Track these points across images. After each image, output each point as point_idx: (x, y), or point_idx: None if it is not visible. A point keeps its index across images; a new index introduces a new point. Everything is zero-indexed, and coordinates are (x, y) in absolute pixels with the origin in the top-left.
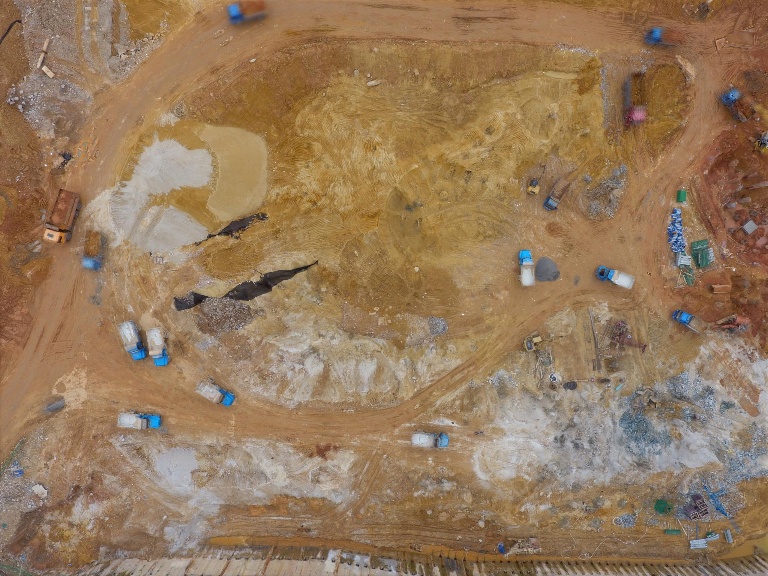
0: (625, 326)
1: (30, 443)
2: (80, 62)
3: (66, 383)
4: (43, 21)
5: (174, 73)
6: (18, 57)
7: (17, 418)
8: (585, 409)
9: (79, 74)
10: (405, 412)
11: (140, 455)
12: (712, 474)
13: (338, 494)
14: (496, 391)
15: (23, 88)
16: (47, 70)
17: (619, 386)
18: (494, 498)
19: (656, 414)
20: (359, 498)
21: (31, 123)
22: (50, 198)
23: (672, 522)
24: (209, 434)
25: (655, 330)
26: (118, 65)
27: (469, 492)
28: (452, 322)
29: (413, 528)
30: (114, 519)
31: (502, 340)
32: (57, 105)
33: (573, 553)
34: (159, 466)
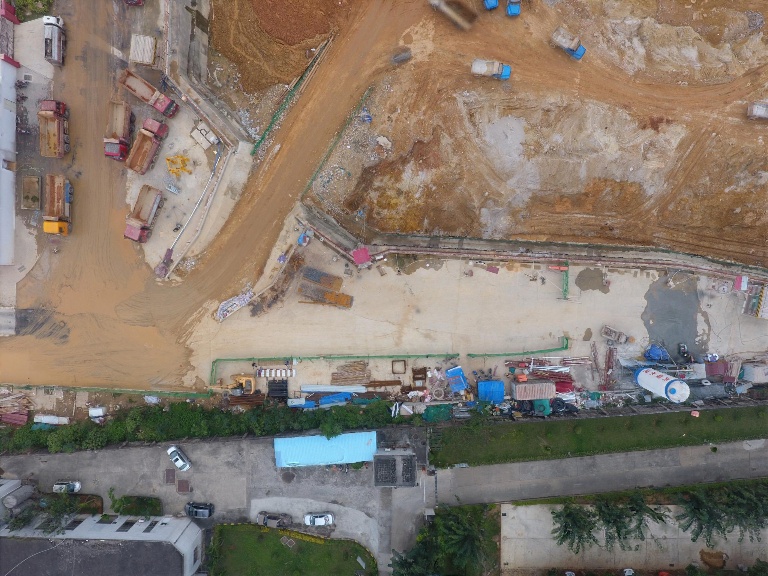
0: None
1: (378, 91)
2: None
3: (413, 34)
4: None
5: None
6: None
7: (366, 65)
8: None
9: None
10: (737, 89)
11: (472, 122)
12: None
13: (652, 184)
14: None
15: None
16: None
17: None
18: None
19: None
20: (670, 191)
21: None
22: None
23: None
24: (553, 92)
25: None
26: None
27: None
28: None
29: (707, 240)
30: (441, 189)
31: None
32: None
33: None
34: (490, 135)
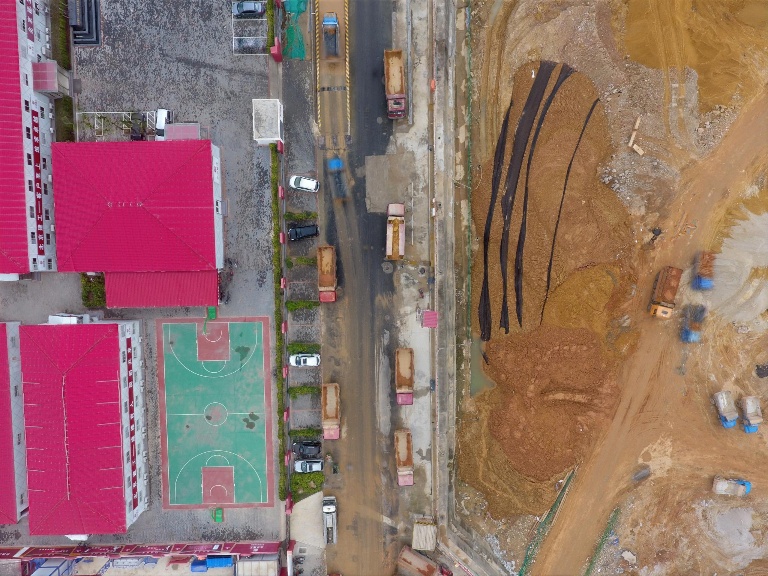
0: None
1: (623, 512)
2: (667, 138)
3: (652, 452)
4: (635, 100)
5: (752, 145)
6: (604, 136)
7: (610, 488)
8: None
9: (665, 150)
10: None
11: (703, 517)
12: None
13: None
14: None
15: (614, 166)
16: (638, 148)
17: None
18: None
19: None
20: None
21: (622, 201)
22: (639, 273)
23: None
24: None
25: None
26: (697, 139)
27: None
28: None
29: None
30: None
31: None
32: (648, 182)
33: None
34: (721, 527)
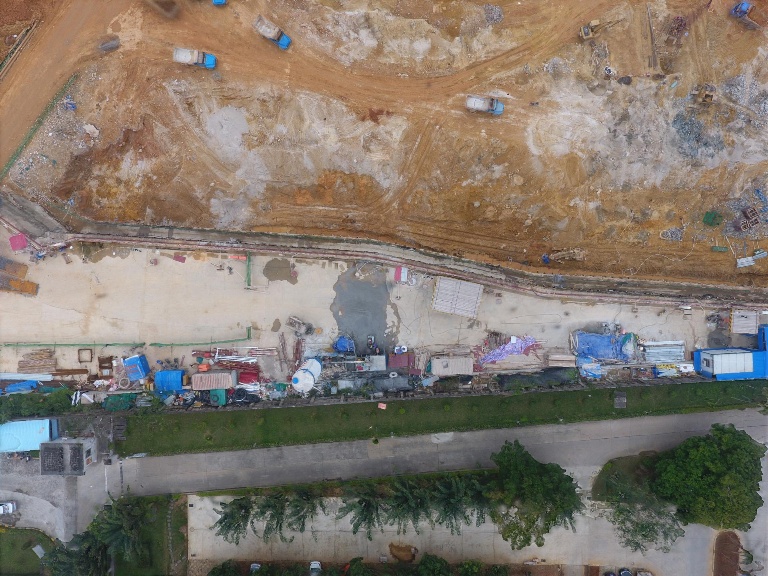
0: (683, 20)
1: (84, 79)
2: None
3: (122, 22)
4: None
5: None
6: None
7: (71, 53)
8: (640, 102)
9: None
10: (460, 82)
11: (191, 112)
12: (763, 186)
13: (386, 177)
14: (551, 76)
15: None
16: None
17: (674, 83)
18: (544, 185)
19: (710, 118)
20: (407, 184)
21: None
22: None
23: (720, 239)
24: (263, 82)
25: (713, 29)
26: None
27: (520, 176)
28: (508, 11)
29: (457, 234)
30: (162, 178)
31: (558, 31)
32: None
33: (618, 268)
34: (210, 124)
